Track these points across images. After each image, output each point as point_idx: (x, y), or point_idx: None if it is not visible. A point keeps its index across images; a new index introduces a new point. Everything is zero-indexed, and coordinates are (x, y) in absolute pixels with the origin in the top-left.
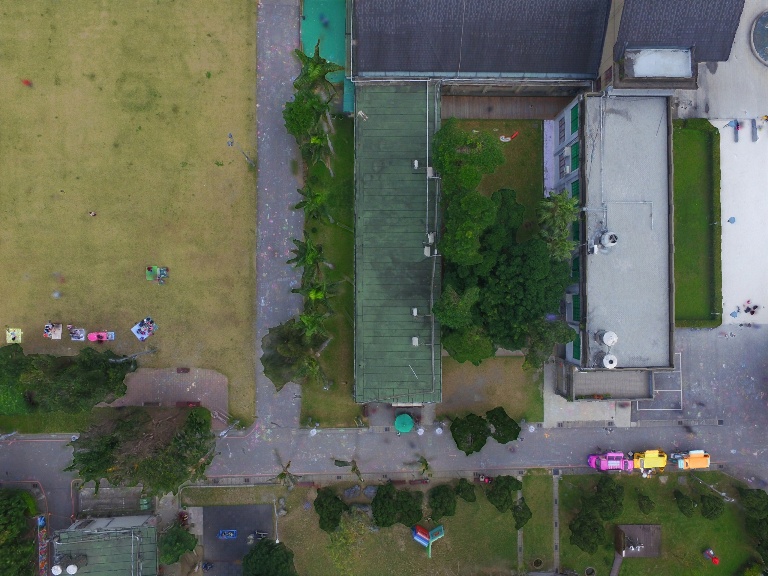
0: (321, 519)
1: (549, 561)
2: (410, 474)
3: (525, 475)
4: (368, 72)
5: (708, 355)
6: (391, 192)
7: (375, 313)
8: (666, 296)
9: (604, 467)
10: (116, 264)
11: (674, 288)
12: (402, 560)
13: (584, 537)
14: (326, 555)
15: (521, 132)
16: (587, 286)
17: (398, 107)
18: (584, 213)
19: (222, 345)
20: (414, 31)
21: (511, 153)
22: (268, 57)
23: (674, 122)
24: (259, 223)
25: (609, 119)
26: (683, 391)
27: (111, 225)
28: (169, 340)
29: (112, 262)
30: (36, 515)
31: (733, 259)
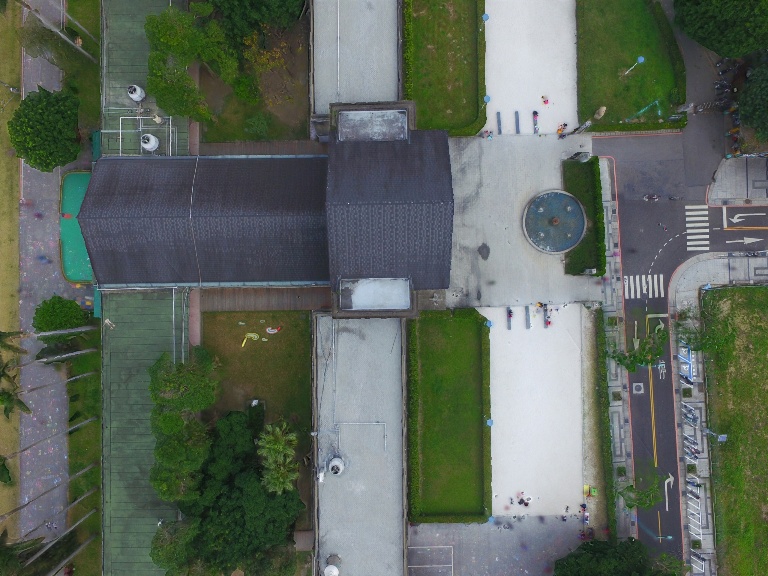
0: None
1: None
2: None
3: None
4: (109, 284)
5: (480, 548)
6: (139, 401)
7: (123, 524)
8: (400, 519)
9: None
10: None
11: (405, 514)
12: None
13: None
14: None
15: (288, 323)
16: (316, 512)
17: (145, 314)
18: (313, 438)
19: None
20: (146, 249)
21: (278, 345)
22: (31, 253)
23: (441, 313)
24: (22, 421)
25: (342, 338)
26: None
27: None
28: None
29: None
30: None
31: (507, 449)
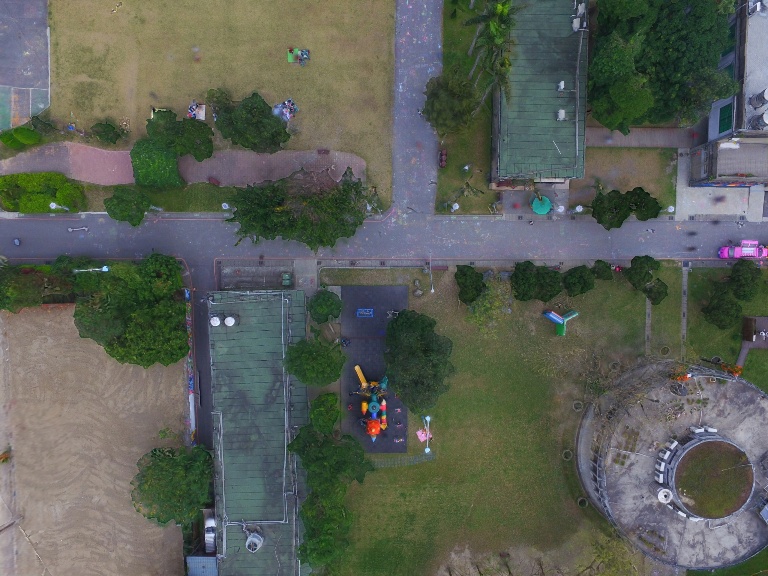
0: (463, 288)
1: (676, 350)
2: (542, 262)
3: None
4: None
5: None
6: None
7: (520, 88)
8: None
9: (738, 254)
10: (258, 46)
11: None
12: (532, 344)
13: (722, 311)
14: (459, 336)
15: None
16: (746, 47)
17: None
18: None
19: (361, 129)
20: None
21: None
22: None
23: None
24: (398, 8)
25: None
26: None
27: (253, 6)
28: (309, 123)
29: (254, 44)
30: (183, 287)
31: None
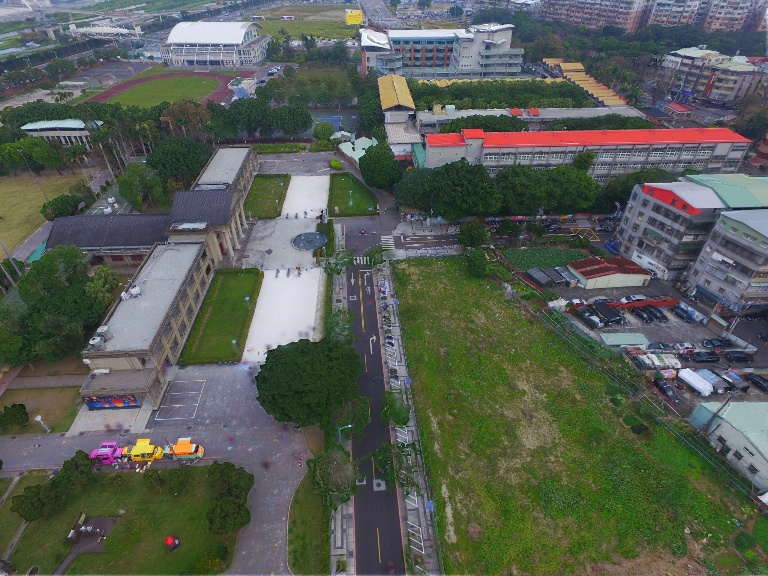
0: None
1: None
2: None
3: (24, 476)
4: None
5: (227, 380)
6: None
7: None
8: None
9: (94, 454)
10: None
11: (168, 310)
12: None
13: None
14: None
15: None
16: (110, 312)
17: None
18: (128, 282)
19: None
20: (81, 231)
21: None
22: None
23: (236, 269)
24: None
25: None
26: (199, 405)
27: None
28: None
29: None
30: None
31: (262, 328)
